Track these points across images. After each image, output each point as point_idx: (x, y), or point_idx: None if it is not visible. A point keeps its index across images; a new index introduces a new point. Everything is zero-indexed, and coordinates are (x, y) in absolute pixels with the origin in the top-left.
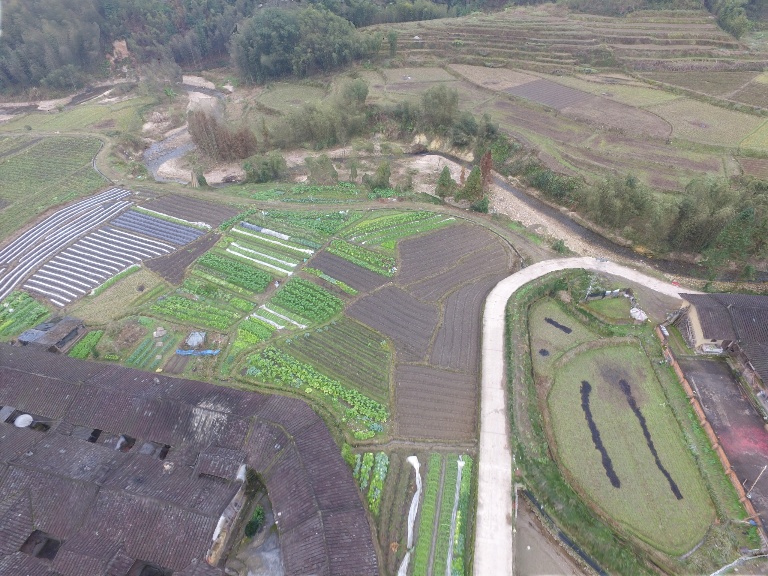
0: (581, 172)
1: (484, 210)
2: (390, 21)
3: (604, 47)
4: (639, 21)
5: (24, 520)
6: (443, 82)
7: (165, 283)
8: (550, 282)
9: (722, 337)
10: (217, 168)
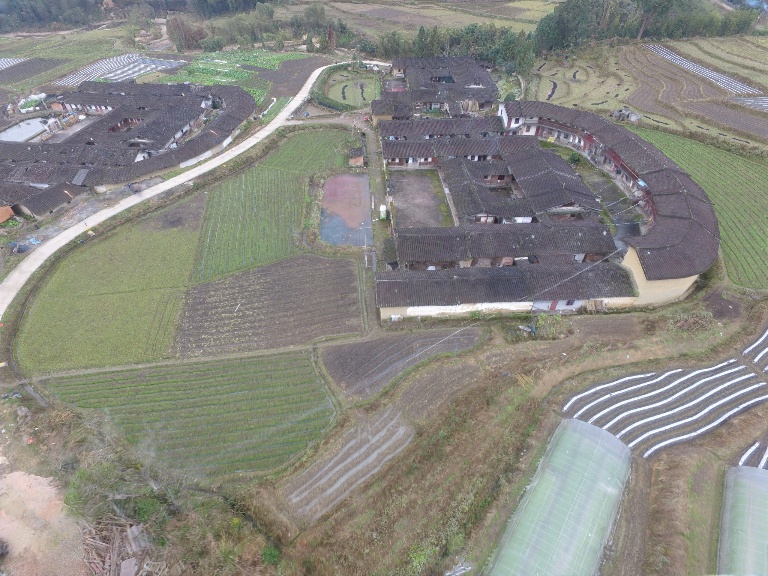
0: None
1: None
2: None
3: None
4: None
5: (136, 104)
6: None
7: (169, 75)
8: (344, 64)
9: (399, 67)
10: (186, 52)
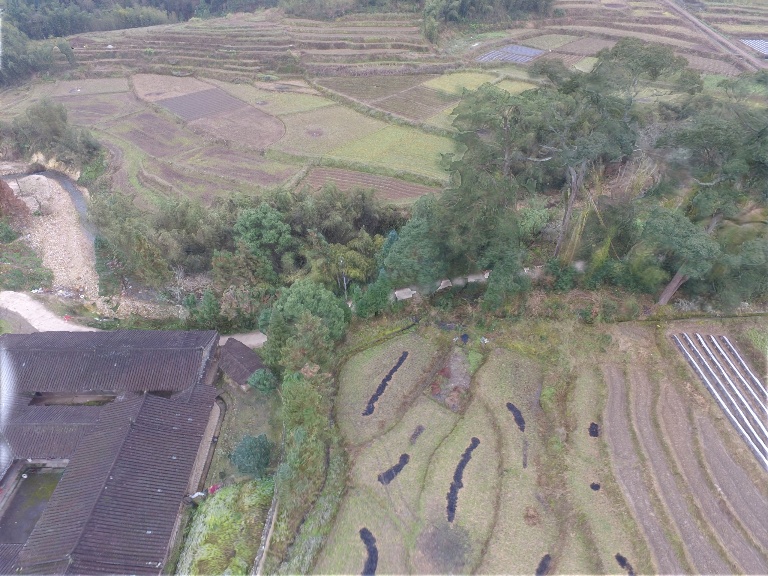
0: (139, 190)
1: (7, 237)
2: (110, 29)
3: (289, 53)
4: (347, 25)
5: None
6: (110, 94)
7: None
8: None
9: None
10: None
